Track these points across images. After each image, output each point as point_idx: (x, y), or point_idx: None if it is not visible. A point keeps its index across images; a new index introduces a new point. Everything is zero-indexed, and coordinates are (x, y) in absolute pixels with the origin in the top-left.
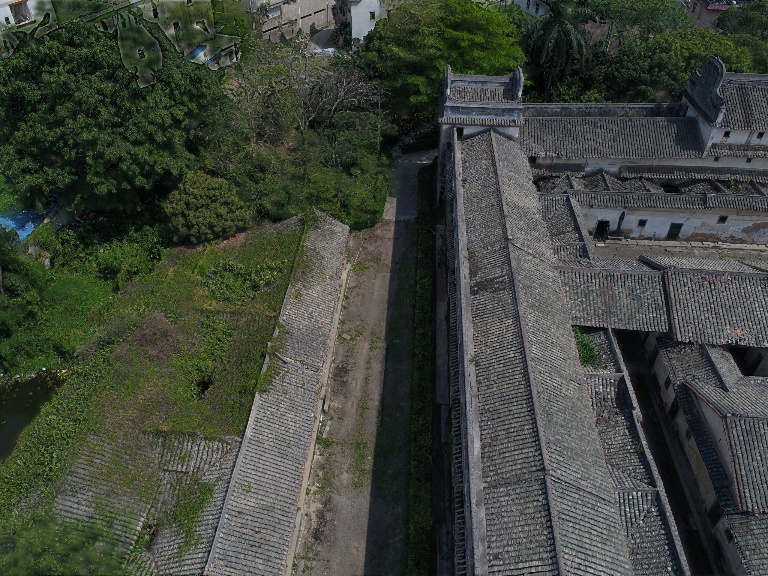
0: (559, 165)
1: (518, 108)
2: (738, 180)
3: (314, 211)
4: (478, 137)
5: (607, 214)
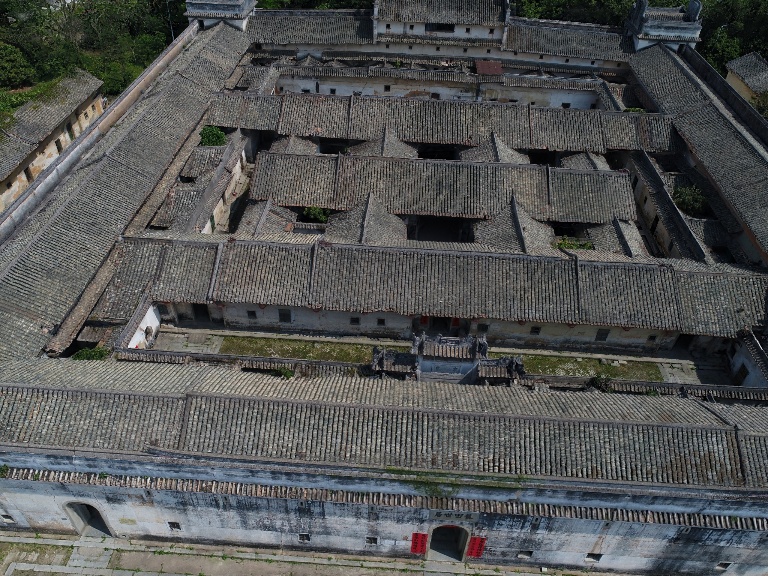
0: (278, 51)
1: (237, 4)
2: (403, 62)
3: (77, 69)
4: (213, 27)
5: (306, 84)
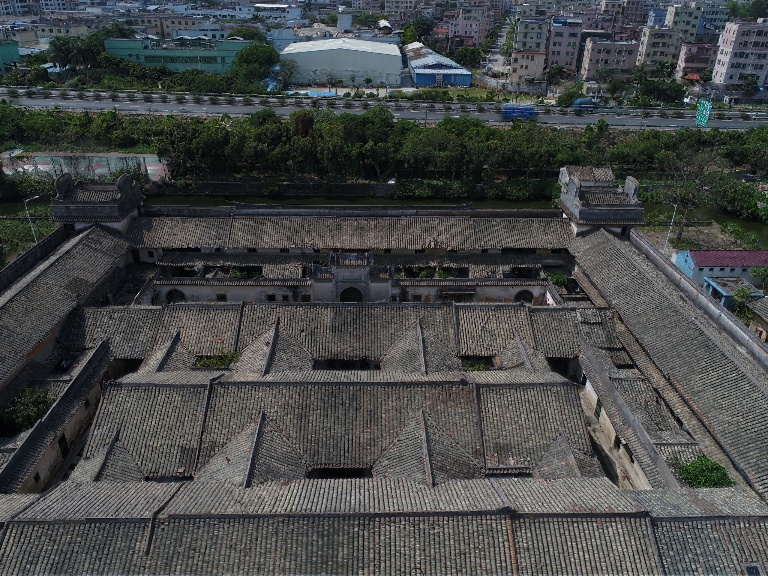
0: None
1: None
2: None
3: None
4: None
5: None
